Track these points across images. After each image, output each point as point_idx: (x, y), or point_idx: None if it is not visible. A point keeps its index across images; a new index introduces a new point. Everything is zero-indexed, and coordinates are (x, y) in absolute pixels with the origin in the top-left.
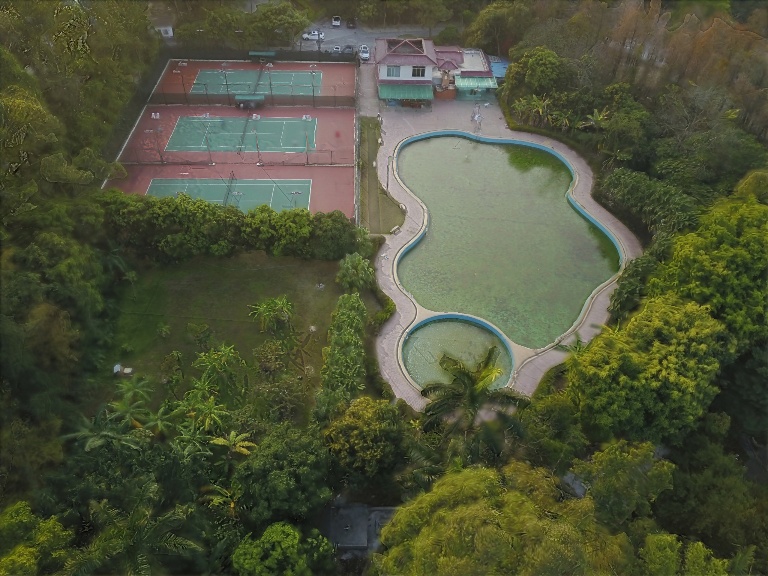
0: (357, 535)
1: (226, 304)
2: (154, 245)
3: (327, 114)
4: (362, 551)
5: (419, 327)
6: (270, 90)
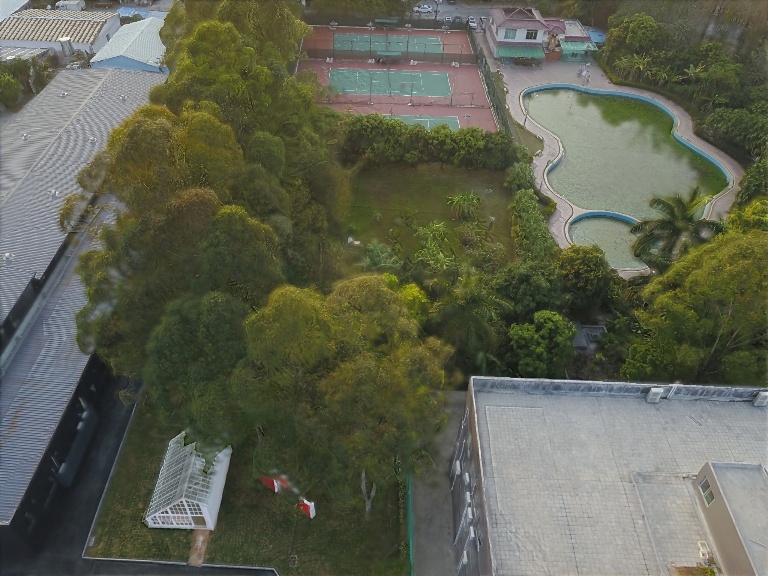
0: (578, 340)
1: (418, 201)
2: (361, 152)
3: (454, 69)
4: (583, 350)
5: (576, 221)
6: (407, 47)
